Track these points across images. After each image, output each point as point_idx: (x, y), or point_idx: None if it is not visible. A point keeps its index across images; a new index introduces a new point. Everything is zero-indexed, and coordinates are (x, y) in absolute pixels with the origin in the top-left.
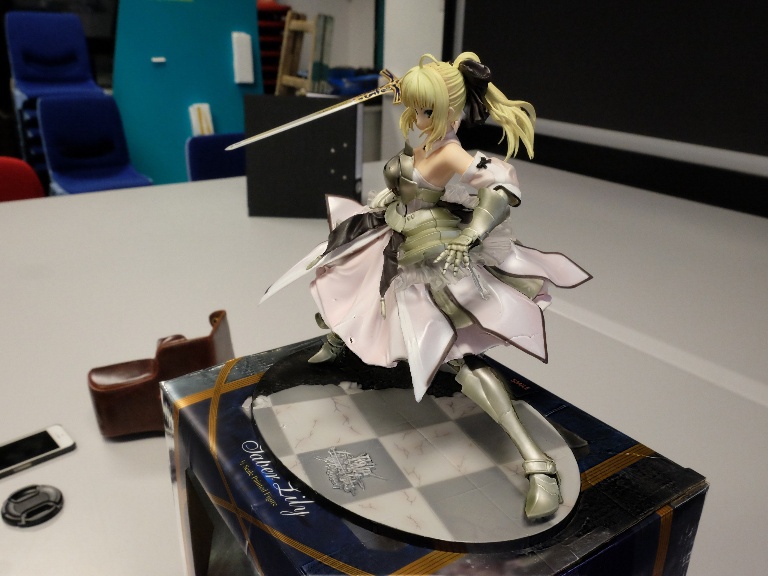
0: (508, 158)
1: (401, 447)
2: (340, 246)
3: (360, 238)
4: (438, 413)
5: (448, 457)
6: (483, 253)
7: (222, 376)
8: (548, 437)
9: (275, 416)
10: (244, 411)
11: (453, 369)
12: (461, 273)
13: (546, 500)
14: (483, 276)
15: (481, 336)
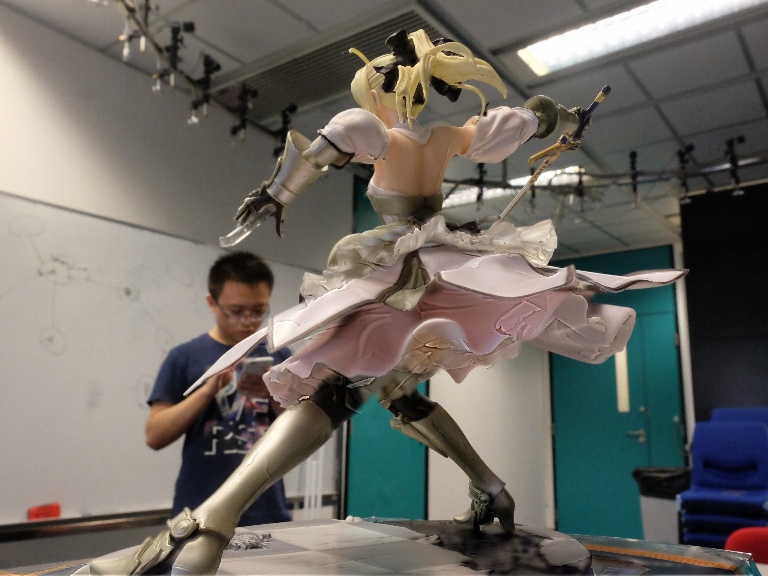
0: (409, 115)
1: None
2: None
3: None
4: None
5: (284, 570)
6: (388, 252)
7: None
8: None
9: None
10: None
11: (564, 563)
12: None
13: (123, 561)
14: None
15: None
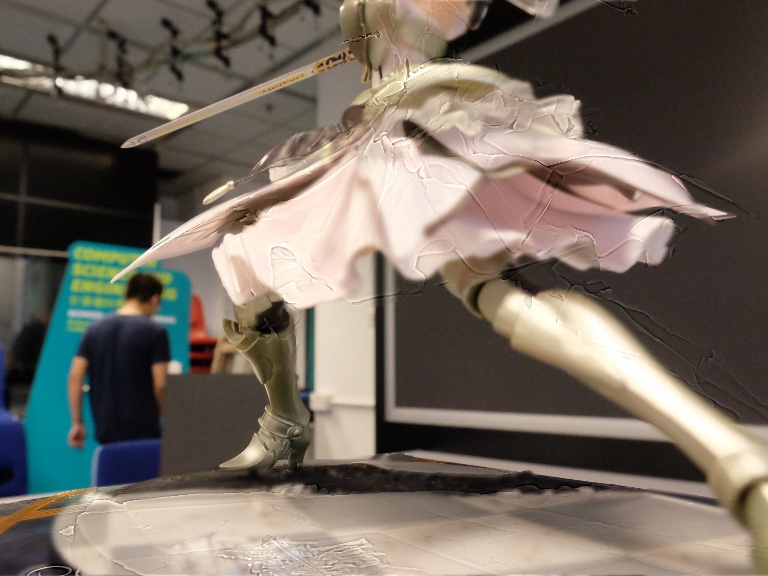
0: None
1: (441, 537)
2: (287, 158)
3: (323, 154)
4: (498, 505)
5: (565, 541)
6: None
7: (35, 504)
8: (761, 510)
9: (130, 518)
10: (60, 534)
11: (496, 471)
12: (536, 102)
13: None
14: (571, 138)
15: (601, 212)
